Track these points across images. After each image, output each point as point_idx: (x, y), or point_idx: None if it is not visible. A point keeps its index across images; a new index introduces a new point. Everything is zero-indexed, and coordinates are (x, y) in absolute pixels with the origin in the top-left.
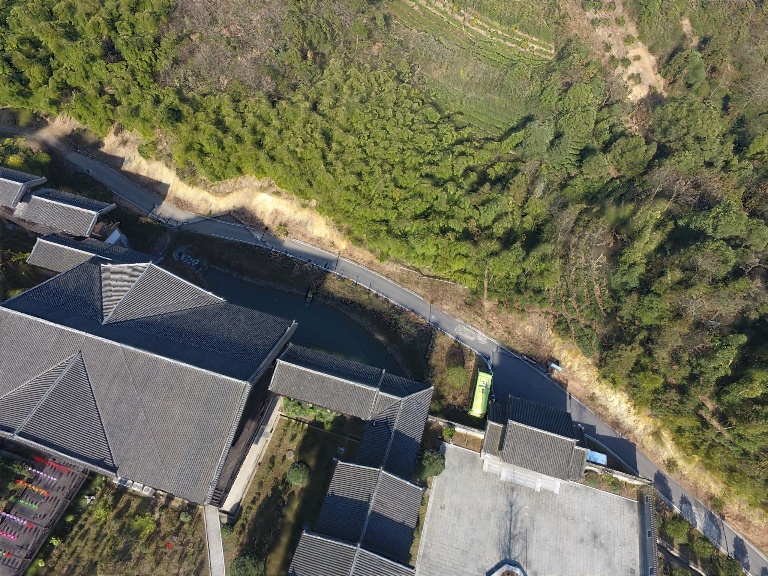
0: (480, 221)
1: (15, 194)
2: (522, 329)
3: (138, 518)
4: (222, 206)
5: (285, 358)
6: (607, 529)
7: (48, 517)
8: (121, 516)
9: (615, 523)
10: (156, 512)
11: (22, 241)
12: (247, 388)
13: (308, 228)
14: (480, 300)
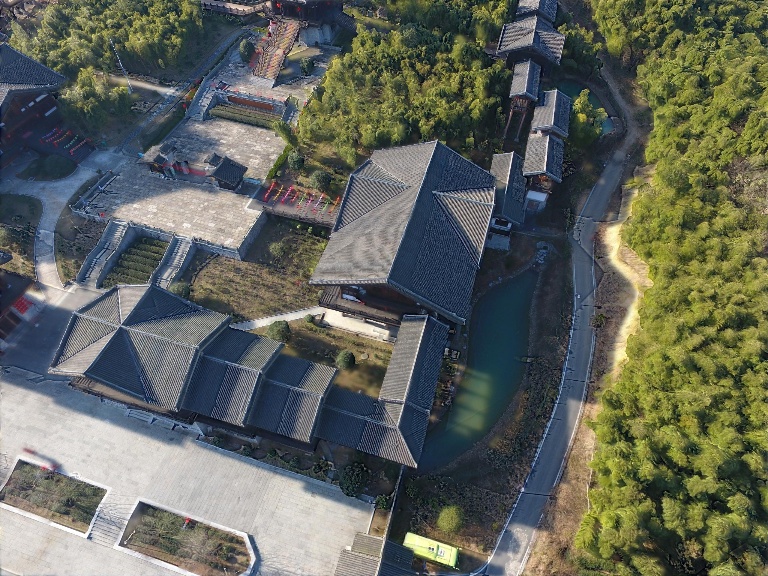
0: (711, 571)
1: (543, 125)
2: None
3: None
4: (610, 264)
5: (431, 322)
6: None
7: (322, 220)
8: None
9: None
10: None
11: (523, 154)
12: (384, 280)
13: (614, 345)
14: (575, 573)
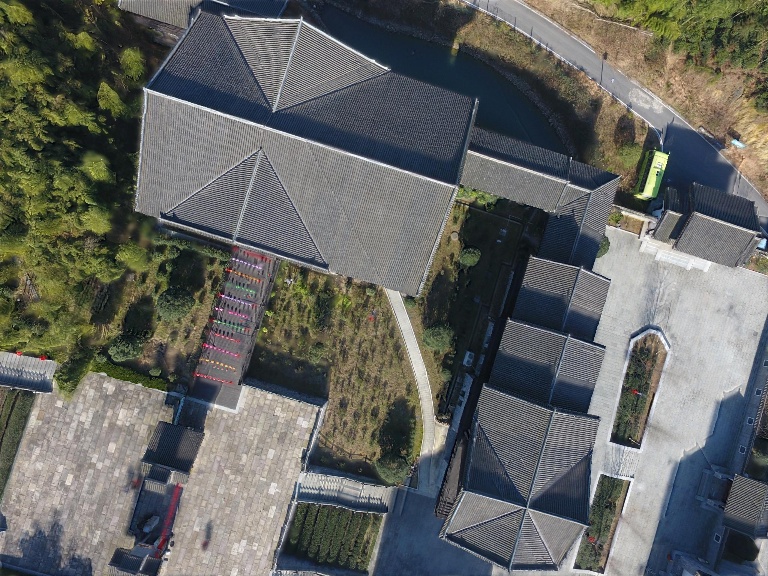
0: None
1: None
2: (708, 94)
3: (329, 293)
4: None
5: None
6: (743, 302)
7: (259, 296)
8: (314, 291)
9: (752, 297)
10: (343, 287)
11: None
12: (455, 192)
13: None
14: (664, 53)
